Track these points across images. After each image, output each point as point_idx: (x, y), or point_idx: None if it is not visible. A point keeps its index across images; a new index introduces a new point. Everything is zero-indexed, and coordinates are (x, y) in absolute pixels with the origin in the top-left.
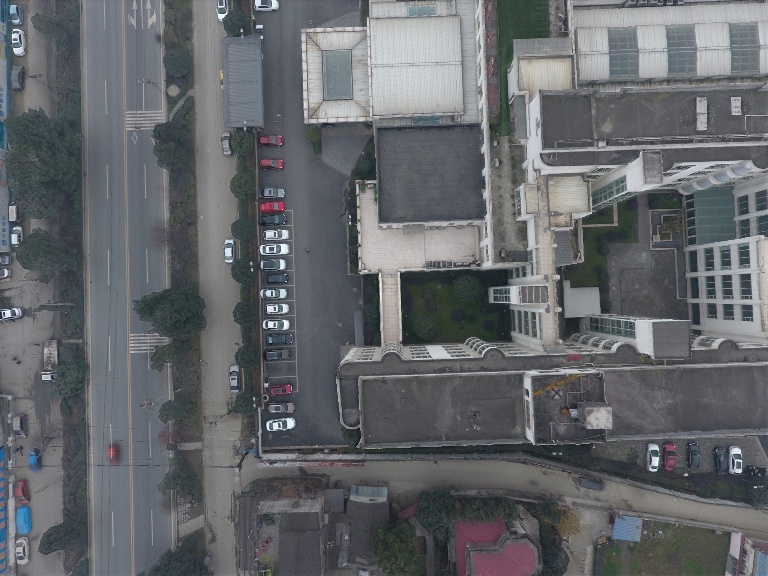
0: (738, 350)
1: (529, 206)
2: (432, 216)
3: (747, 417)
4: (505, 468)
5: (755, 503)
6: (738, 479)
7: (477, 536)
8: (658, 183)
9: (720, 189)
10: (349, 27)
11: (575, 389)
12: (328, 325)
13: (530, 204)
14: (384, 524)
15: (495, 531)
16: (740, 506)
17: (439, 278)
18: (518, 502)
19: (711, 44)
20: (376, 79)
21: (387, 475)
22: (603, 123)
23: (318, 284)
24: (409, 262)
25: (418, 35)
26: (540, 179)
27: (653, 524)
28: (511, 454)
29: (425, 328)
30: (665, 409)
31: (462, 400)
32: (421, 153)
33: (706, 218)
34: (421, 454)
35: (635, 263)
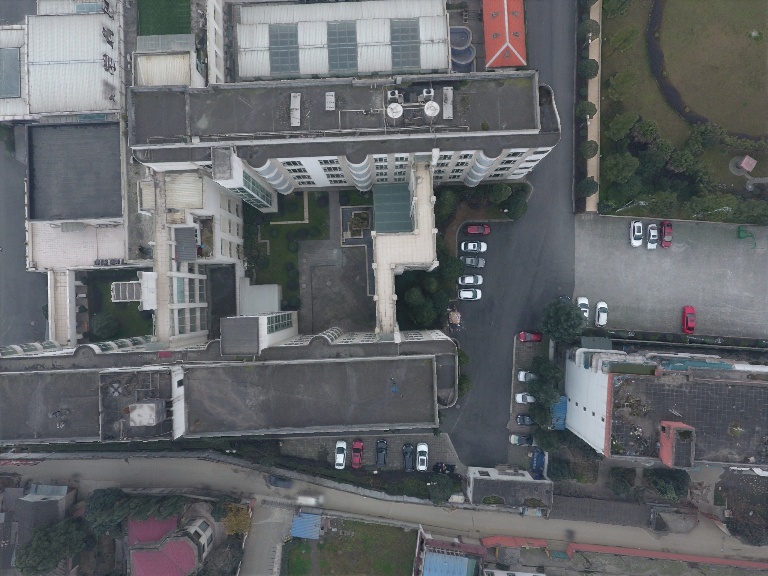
0: (329, 346)
1: (146, 203)
2: (87, 214)
3: (339, 413)
4: (196, 466)
5: (432, 500)
6: (425, 476)
7: (144, 534)
8: (227, 179)
9: (397, 185)
10: (17, 25)
11: (146, 386)
12: (20, 324)
13: (147, 201)
14: (48, 523)
15: (163, 529)
16: (420, 503)
17: (128, 276)
18: (206, 500)
19: (372, 40)
20: (33, 77)
21: (78, 474)
22: (198, 119)
23: (11, 283)
24: (81, 260)
25: (77, 33)
26: (159, 176)
27: (343, 522)
28: (199, 452)
29: (97, 326)
30: (257, 406)
31: (54, 398)
32: (76, 151)
33: (383, 214)
34: (110, 452)
35: (326, 260)
